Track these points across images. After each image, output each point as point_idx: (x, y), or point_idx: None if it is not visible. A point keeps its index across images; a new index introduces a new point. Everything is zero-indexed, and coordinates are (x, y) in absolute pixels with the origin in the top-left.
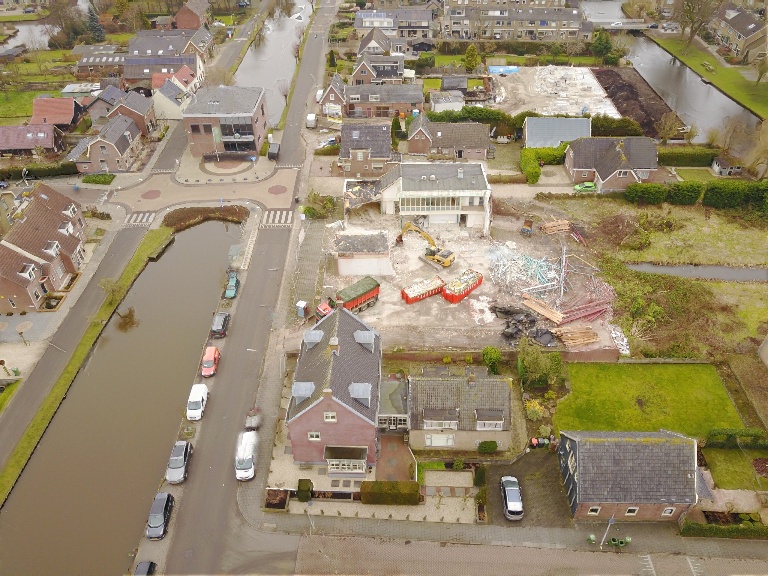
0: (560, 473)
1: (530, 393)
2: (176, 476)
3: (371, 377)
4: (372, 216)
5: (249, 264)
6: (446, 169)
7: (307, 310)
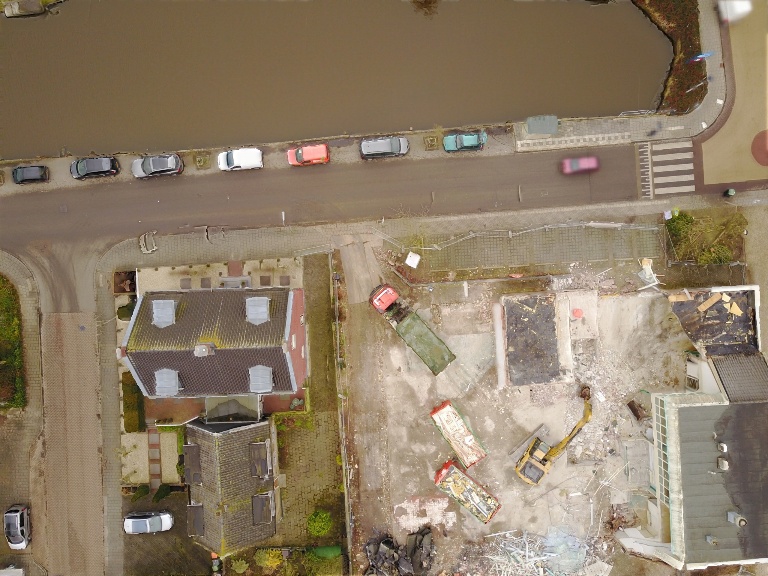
0: (185, 574)
1: (296, 557)
2: (137, 169)
3: (213, 387)
4: (679, 337)
5: (532, 151)
6: (767, 489)
7: (422, 264)
